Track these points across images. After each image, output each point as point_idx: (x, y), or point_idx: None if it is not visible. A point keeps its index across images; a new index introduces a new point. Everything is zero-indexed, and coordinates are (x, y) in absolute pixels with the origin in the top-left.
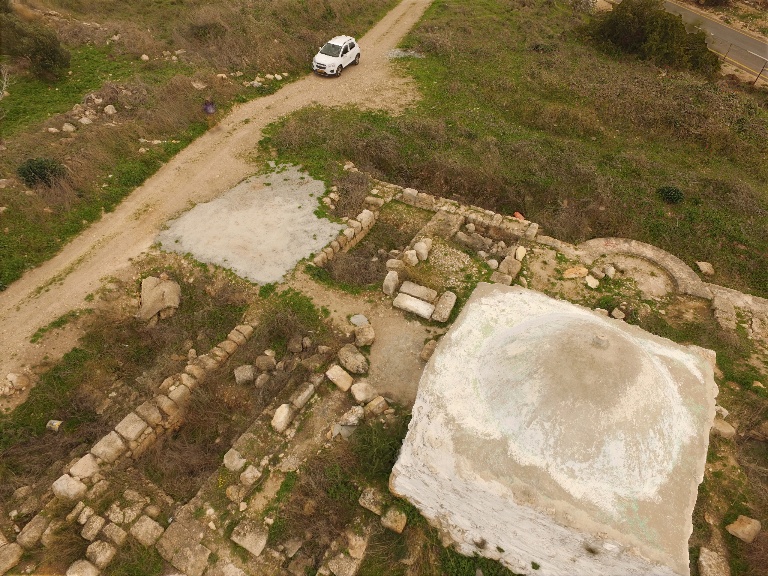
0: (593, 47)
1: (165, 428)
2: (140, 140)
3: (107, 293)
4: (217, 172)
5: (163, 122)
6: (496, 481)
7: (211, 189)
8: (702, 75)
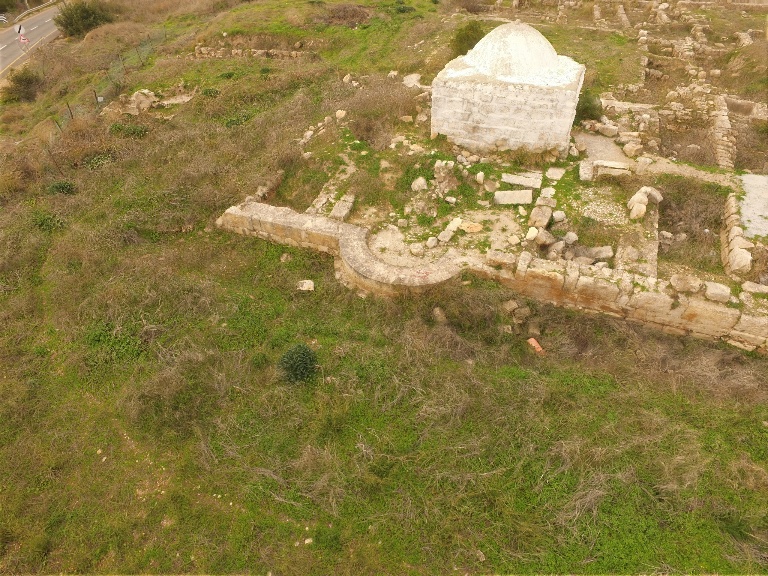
0: None
1: None
2: None
3: None
4: None
5: None
6: None
7: None
8: None
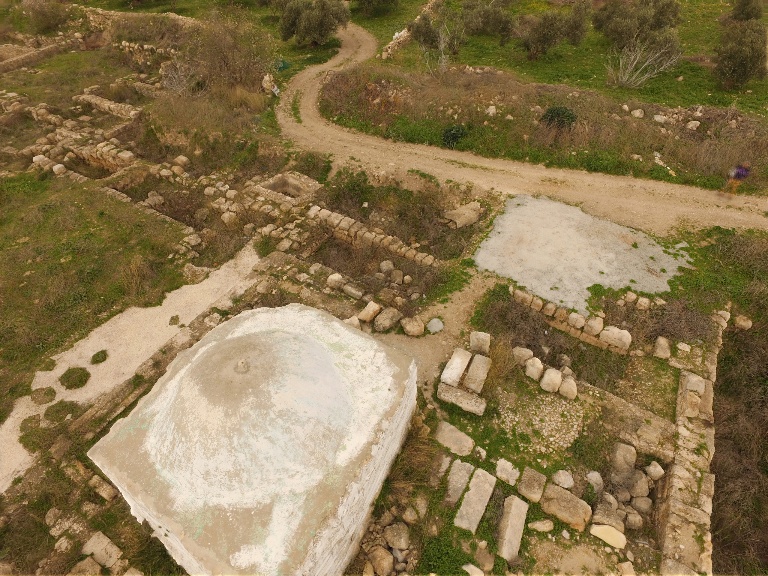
0: None
1: (352, 243)
2: (655, 153)
3: (456, 188)
4: (641, 210)
5: (696, 156)
6: (202, 339)
7: (608, 211)
8: None
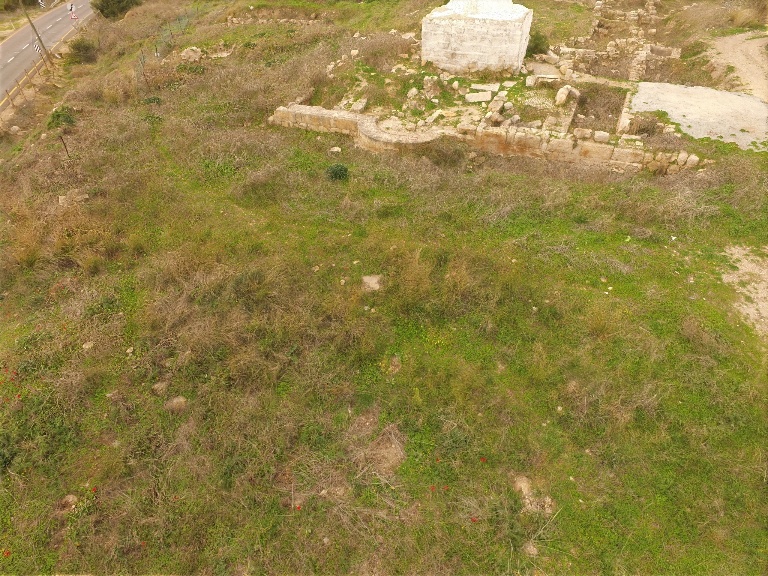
0: None
1: None
2: None
3: None
4: None
5: None
6: None
7: None
8: None
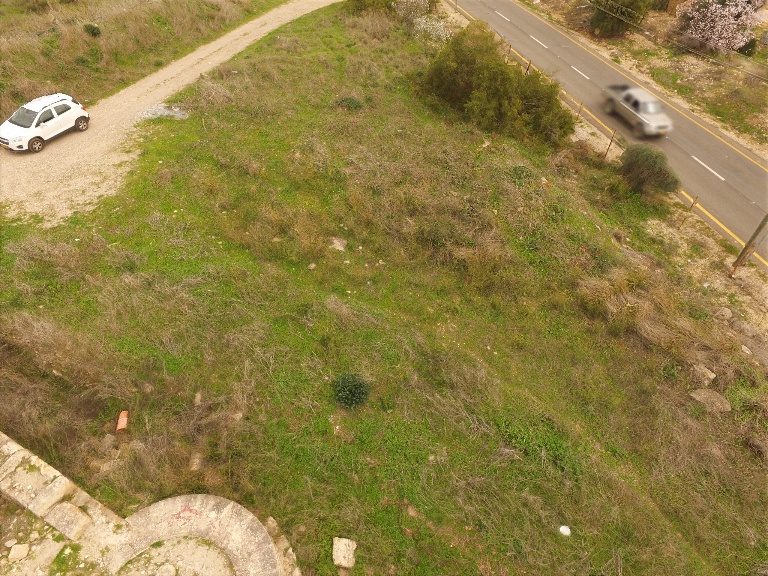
0: (421, 100)
1: None
2: None
3: None
4: None
5: None
6: None
7: None
8: (546, 141)
